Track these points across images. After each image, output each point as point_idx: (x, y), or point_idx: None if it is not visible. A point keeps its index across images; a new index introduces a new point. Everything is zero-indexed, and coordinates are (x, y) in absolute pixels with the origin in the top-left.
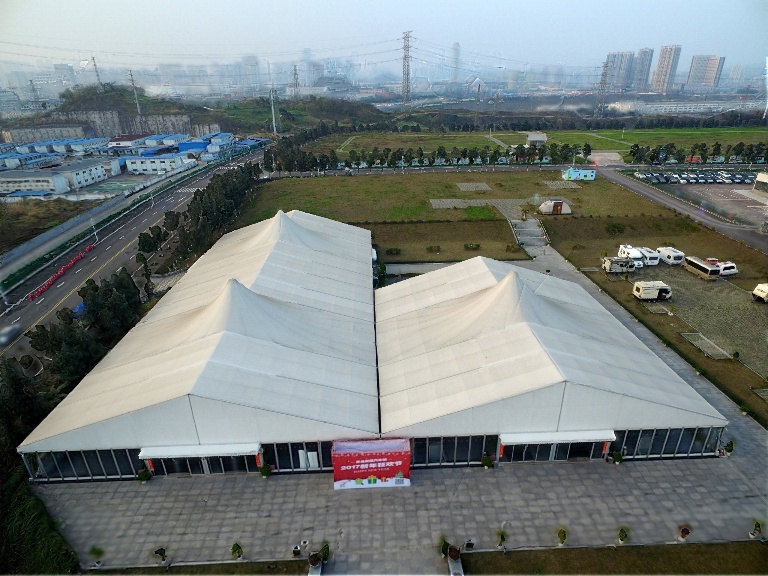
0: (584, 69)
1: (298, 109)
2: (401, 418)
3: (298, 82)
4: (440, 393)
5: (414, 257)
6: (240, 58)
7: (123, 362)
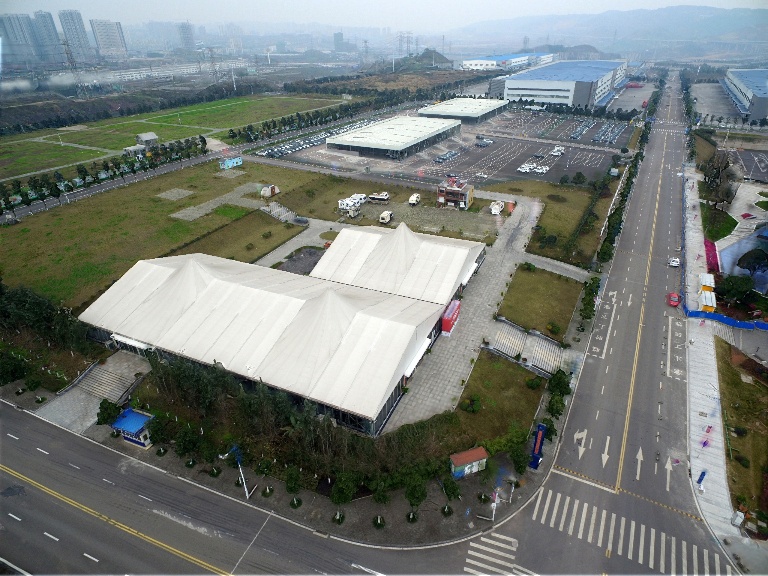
0: (45, 47)
1: None
2: (443, 296)
3: None
4: (440, 281)
5: (248, 257)
6: None
7: (320, 371)
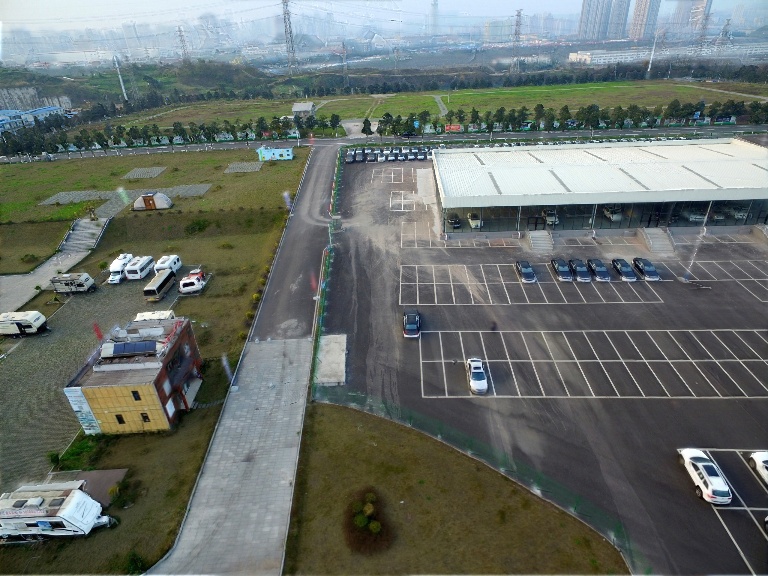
0: (493, 19)
1: (169, 76)
2: None
3: (185, 44)
4: None
5: None
6: (104, 21)
7: None
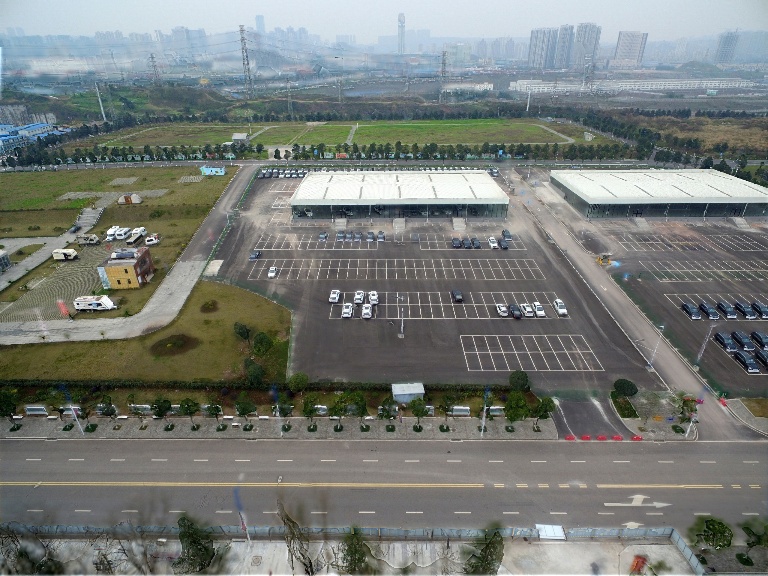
0: (422, 58)
1: (141, 97)
2: None
3: (156, 69)
4: None
5: None
6: (85, 49)
7: None
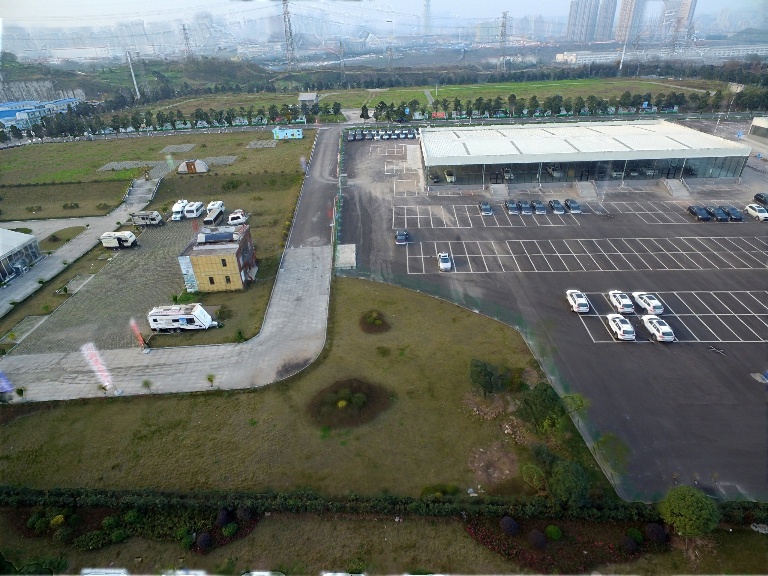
0: (481, 20)
1: (175, 71)
2: None
3: (189, 42)
4: None
5: (7, 216)
6: (114, 19)
7: None
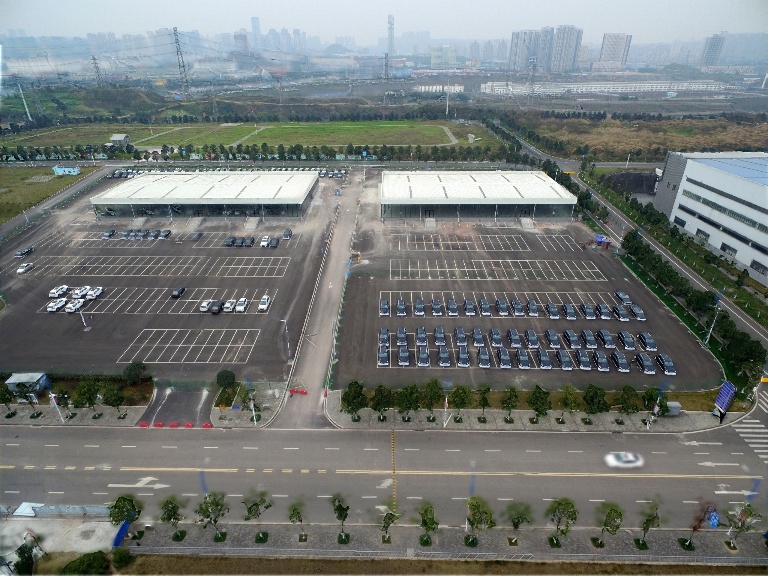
0: (363, 60)
1: (75, 98)
2: None
3: (99, 70)
4: None
5: None
6: (21, 51)
7: None
